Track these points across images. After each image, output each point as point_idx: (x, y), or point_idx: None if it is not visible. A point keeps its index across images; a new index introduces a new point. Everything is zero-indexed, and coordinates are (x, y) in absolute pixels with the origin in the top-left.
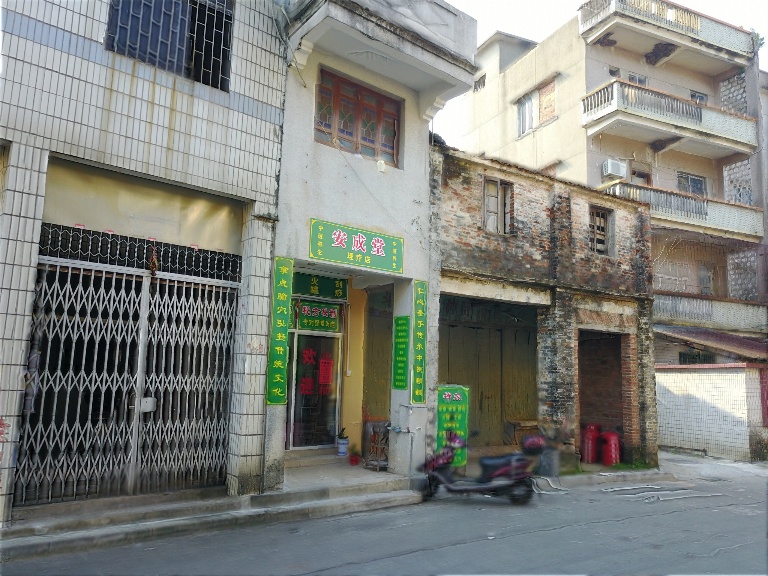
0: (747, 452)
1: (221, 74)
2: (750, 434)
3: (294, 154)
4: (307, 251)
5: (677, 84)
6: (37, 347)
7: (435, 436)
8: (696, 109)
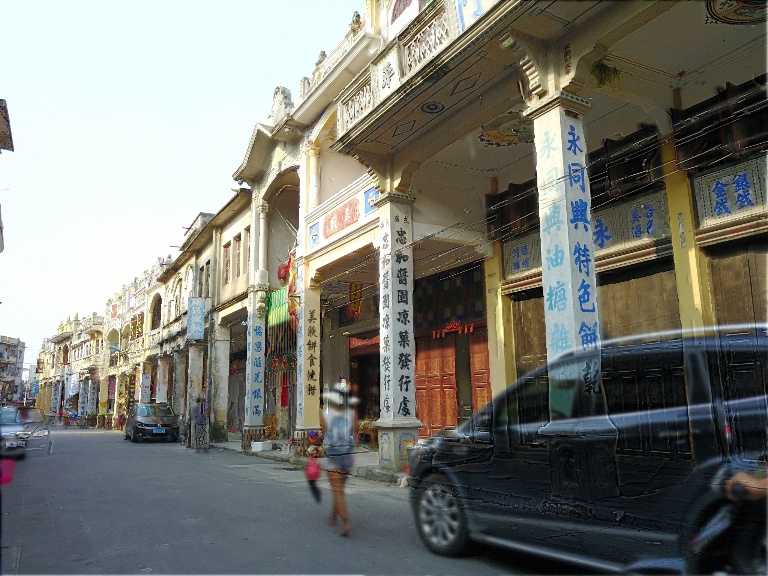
0: None
1: None
2: None
3: None
4: None
5: (3, 347)
6: None
7: None
8: (8, 357)
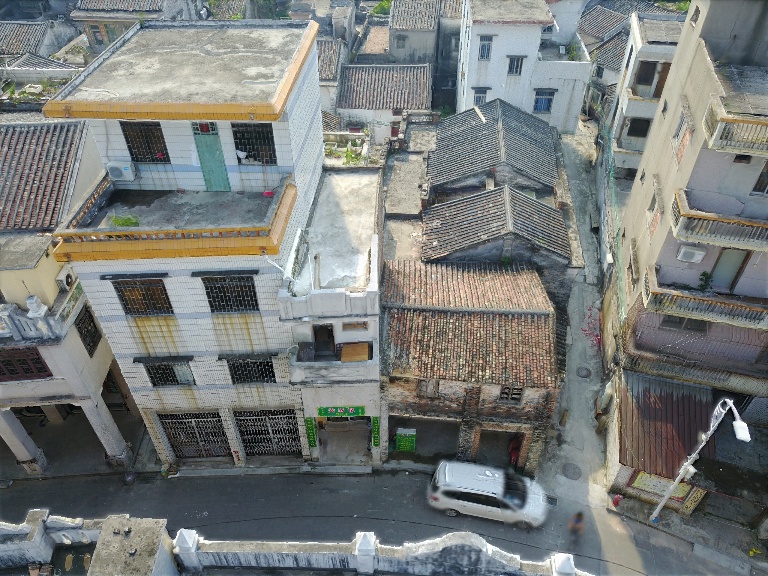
0: (609, 488)
1: (273, 378)
2: (614, 484)
3: (307, 392)
4: (318, 415)
5: None
6: (242, 432)
7: (387, 452)
8: None
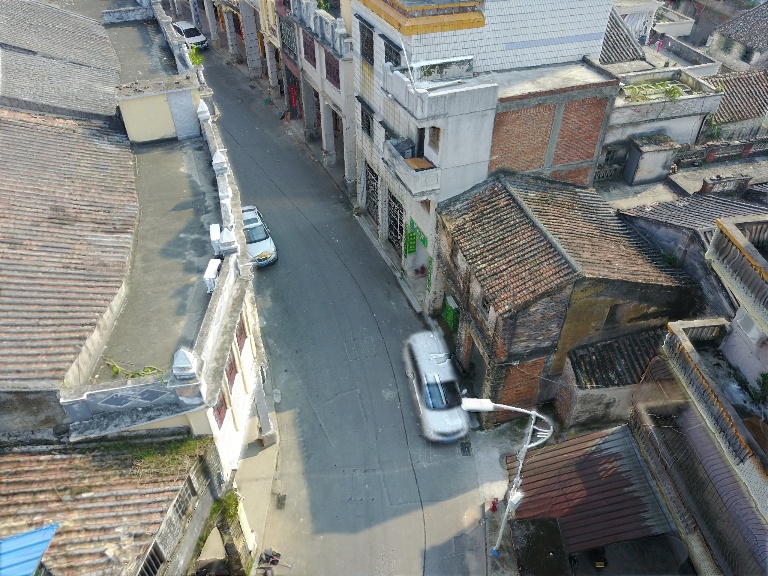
0: None
1: None
2: None
3: None
4: None
5: None
6: None
7: None
8: None
